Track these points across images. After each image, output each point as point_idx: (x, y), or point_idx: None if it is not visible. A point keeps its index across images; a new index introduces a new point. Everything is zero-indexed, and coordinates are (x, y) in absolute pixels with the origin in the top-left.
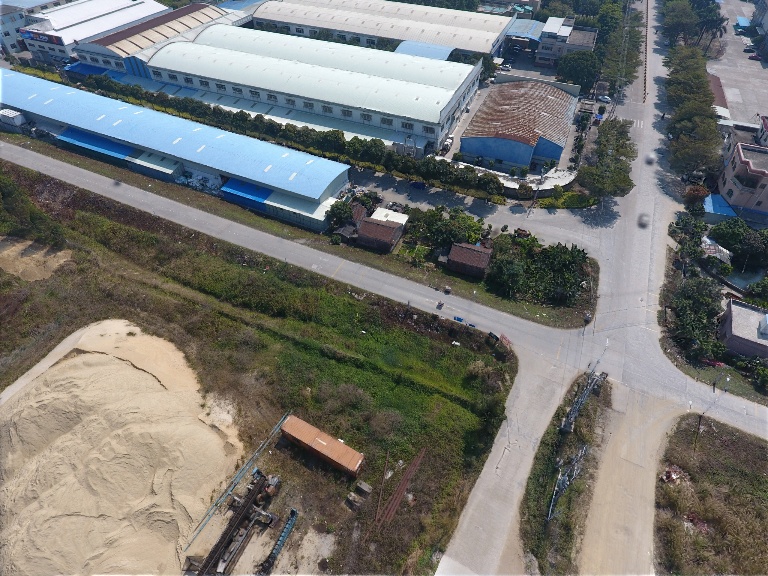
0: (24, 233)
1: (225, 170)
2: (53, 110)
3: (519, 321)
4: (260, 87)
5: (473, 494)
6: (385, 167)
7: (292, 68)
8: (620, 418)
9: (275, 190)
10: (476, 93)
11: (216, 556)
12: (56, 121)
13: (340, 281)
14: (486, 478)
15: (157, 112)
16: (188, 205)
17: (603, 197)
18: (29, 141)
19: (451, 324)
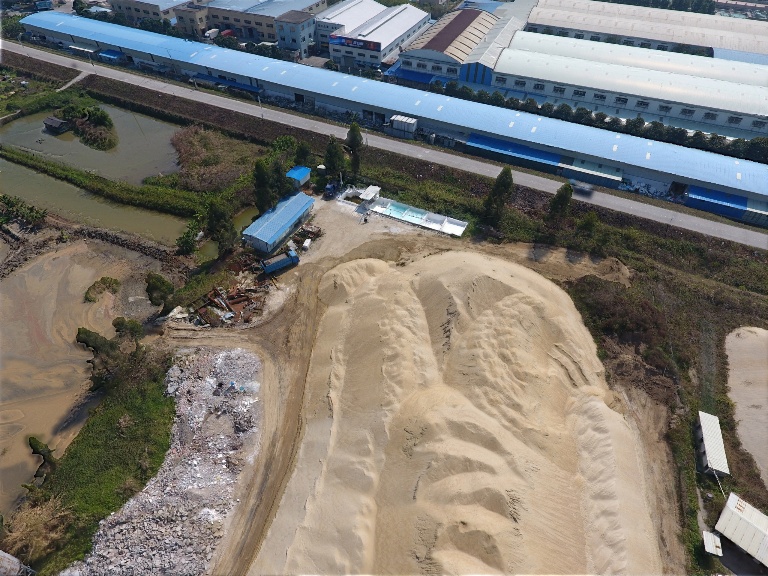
0: (552, 240)
1: (694, 177)
2: (453, 117)
3: None
4: (633, 94)
5: None
6: None
7: (654, 75)
8: None
9: (749, 197)
10: None
11: None
12: (459, 127)
13: None
14: None
15: (552, 119)
16: (682, 212)
17: None
18: (436, 147)
19: None
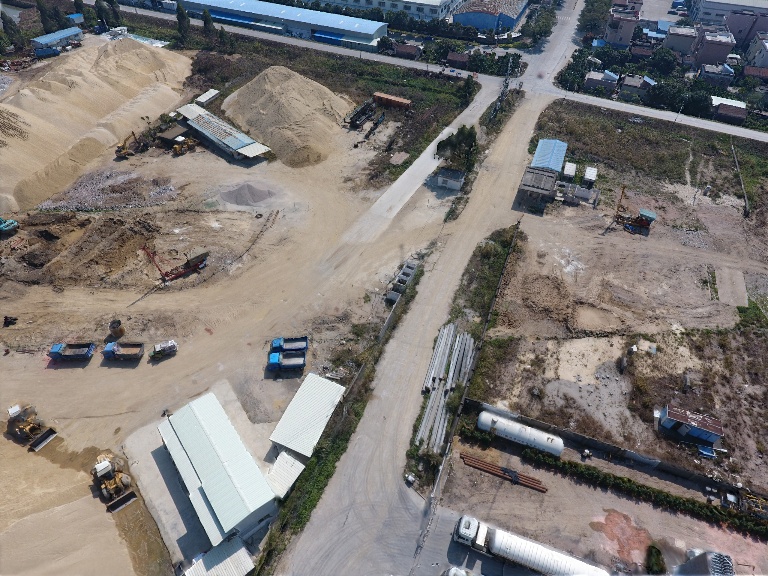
0: (211, 48)
1: (316, 24)
2: None
3: (483, 76)
4: None
5: (459, 116)
6: (408, 28)
7: None
8: (528, 101)
9: (346, 34)
10: (463, 3)
11: (356, 116)
12: (201, 6)
13: (390, 63)
14: (465, 113)
15: None
16: (298, 39)
17: (537, 45)
18: None
19: (449, 75)
